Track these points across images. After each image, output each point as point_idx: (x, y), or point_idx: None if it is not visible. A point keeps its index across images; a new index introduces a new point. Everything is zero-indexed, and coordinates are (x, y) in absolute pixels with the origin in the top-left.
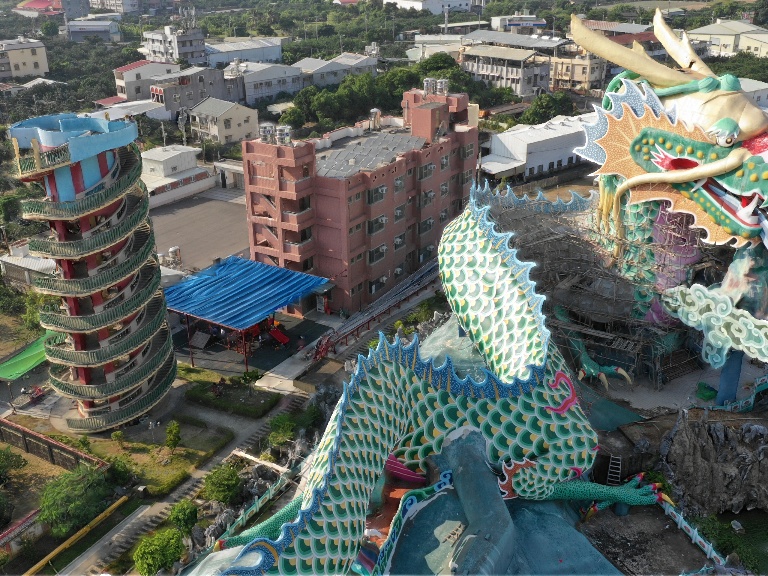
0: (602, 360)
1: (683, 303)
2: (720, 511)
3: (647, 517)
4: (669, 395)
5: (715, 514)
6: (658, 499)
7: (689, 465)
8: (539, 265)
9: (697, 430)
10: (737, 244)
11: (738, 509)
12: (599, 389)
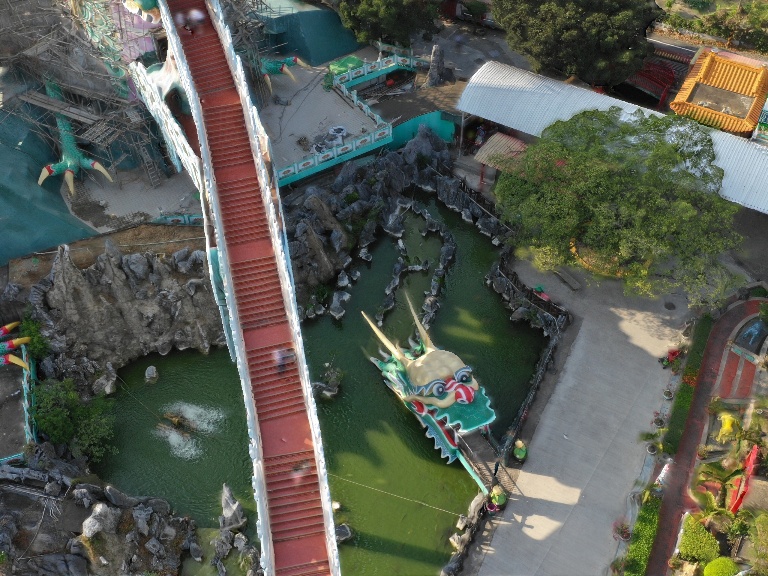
0: (79, 152)
1: (140, 85)
2: (143, 353)
3: (2, 379)
4: (162, 194)
5: (136, 357)
6: (5, 362)
7: (71, 313)
8: (8, 20)
9: (102, 264)
10: (142, 16)
11: (164, 351)
12: (83, 186)
